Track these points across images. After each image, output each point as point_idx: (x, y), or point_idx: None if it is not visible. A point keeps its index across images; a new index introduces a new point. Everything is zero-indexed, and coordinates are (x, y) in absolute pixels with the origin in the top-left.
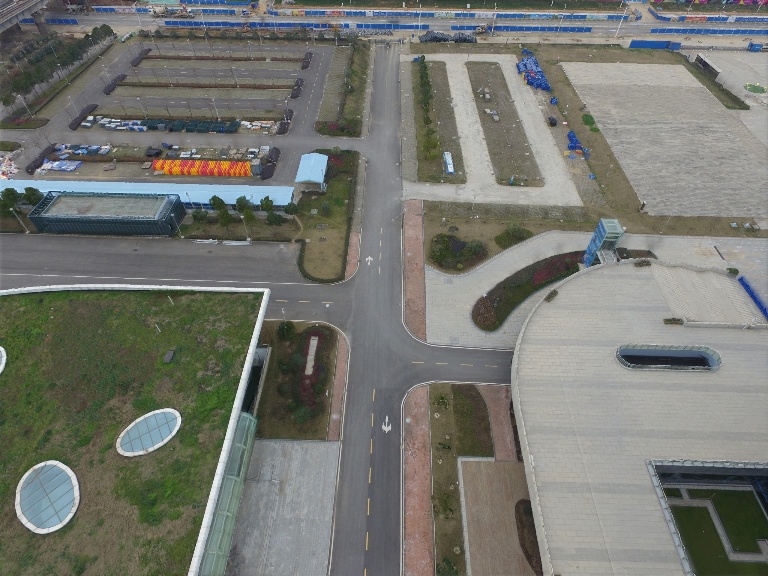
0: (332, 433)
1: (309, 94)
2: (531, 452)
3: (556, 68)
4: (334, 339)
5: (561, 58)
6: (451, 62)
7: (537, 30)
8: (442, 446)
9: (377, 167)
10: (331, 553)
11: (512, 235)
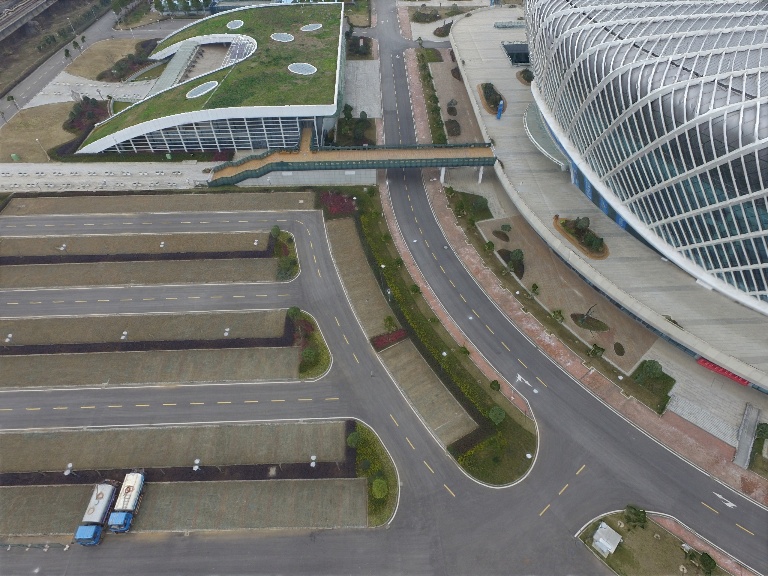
0: (375, 58)
1: None
2: None
3: None
4: (370, 40)
5: None
6: None
7: None
8: (421, 46)
9: None
10: (380, 78)
11: (454, 12)
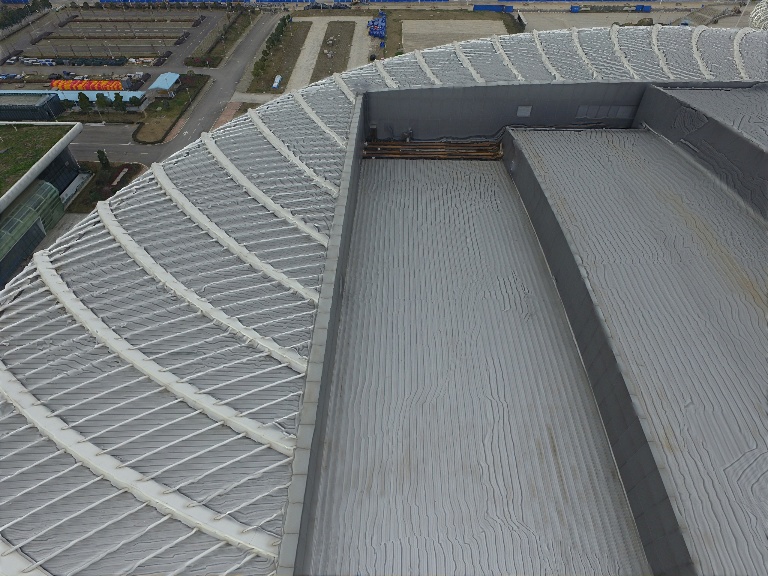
0: None
1: (190, 42)
2: None
3: (397, 24)
4: (139, 170)
5: (406, 17)
6: (317, 22)
7: (404, 1)
8: None
9: (220, 84)
10: None
11: None
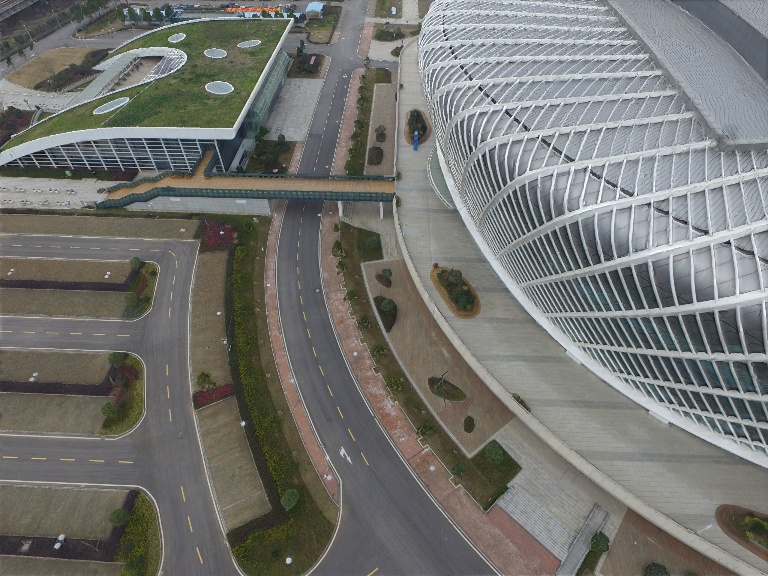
0: (321, 77)
1: None
2: (401, 66)
3: None
4: (323, 57)
5: None
6: None
7: None
8: (365, 67)
9: (352, 12)
10: (319, 98)
11: None
